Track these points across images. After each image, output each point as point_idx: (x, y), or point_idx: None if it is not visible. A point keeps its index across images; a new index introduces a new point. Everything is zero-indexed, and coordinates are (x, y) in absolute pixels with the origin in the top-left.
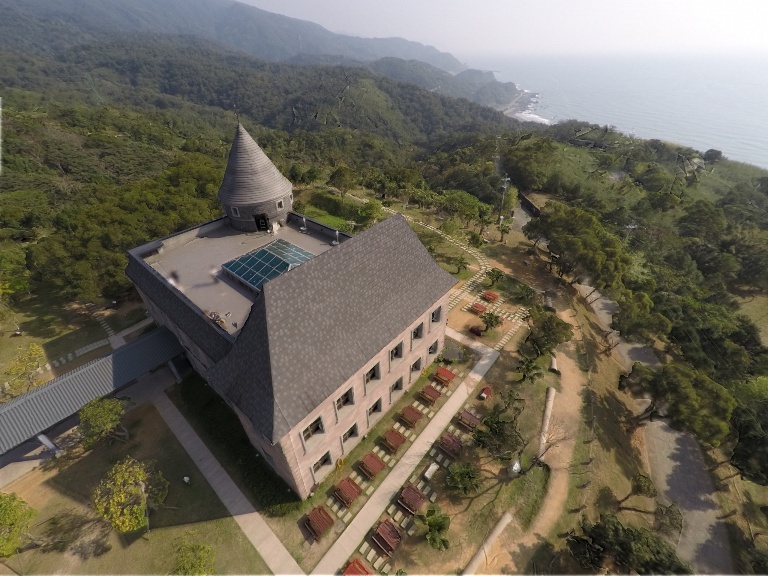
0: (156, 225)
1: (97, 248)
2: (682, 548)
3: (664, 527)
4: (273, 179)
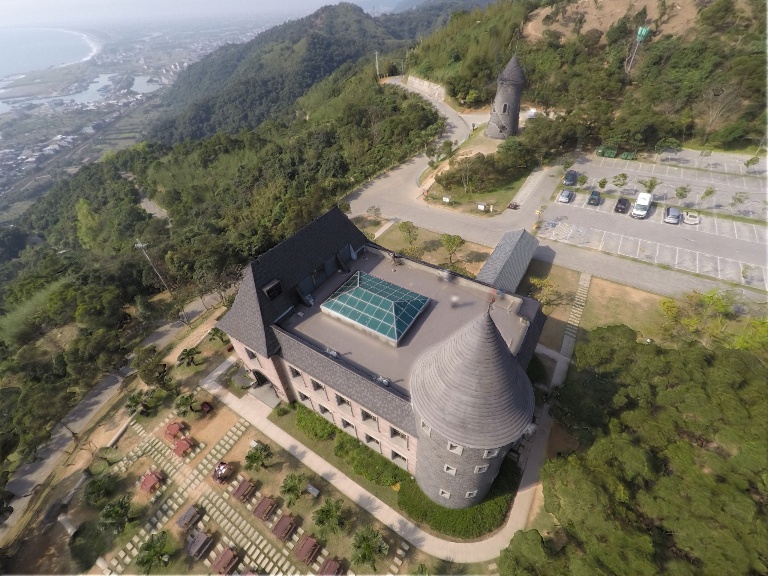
0: (662, 424)
1: (647, 353)
2: (166, 338)
3: (184, 295)
4: (428, 362)
